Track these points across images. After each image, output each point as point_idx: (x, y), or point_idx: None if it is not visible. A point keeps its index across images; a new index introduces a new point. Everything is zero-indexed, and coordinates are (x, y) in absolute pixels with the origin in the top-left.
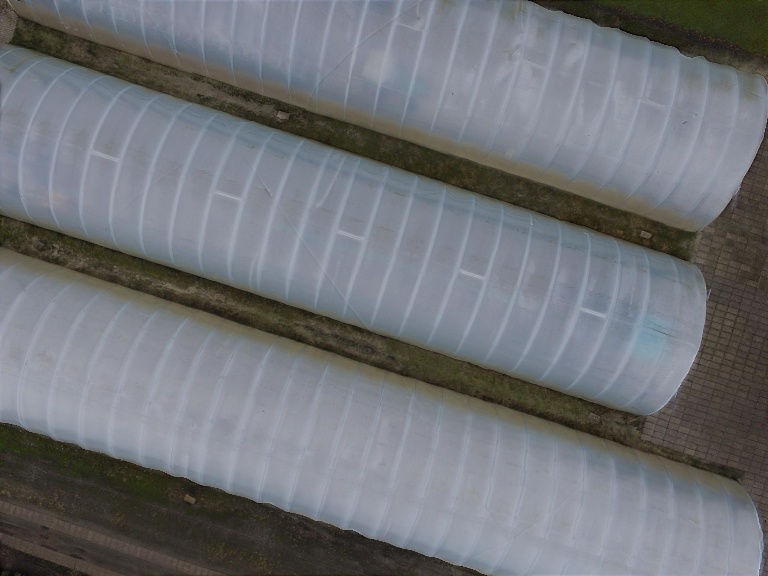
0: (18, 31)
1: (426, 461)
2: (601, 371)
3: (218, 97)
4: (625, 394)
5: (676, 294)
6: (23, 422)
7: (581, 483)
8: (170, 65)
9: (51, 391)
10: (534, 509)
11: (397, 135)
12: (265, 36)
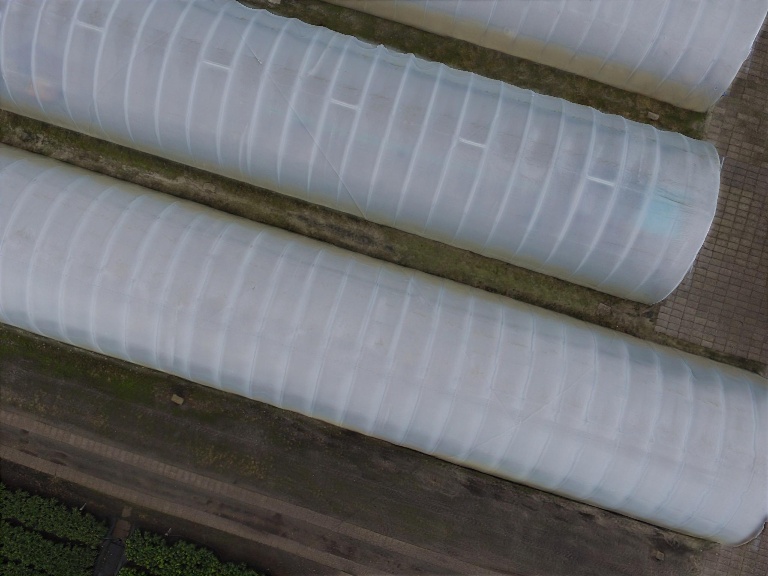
0: None
1: (426, 340)
2: (610, 246)
3: None
4: (637, 273)
5: (687, 162)
6: (1, 308)
7: (592, 365)
8: None
9: (30, 269)
10: (543, 390)
11: (392, 17)
12: None
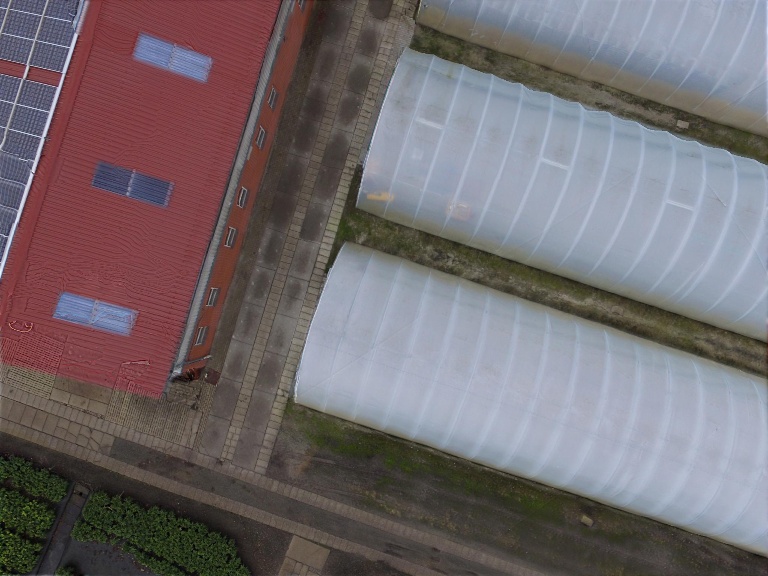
0: (416, 38)
1: None
2: None
3: (616, 105)
4: None
5: None
6: (449, 438)
7: None
8: (569, 73)
9: (498, 406)
10: None
11: None
12: (708, 44)
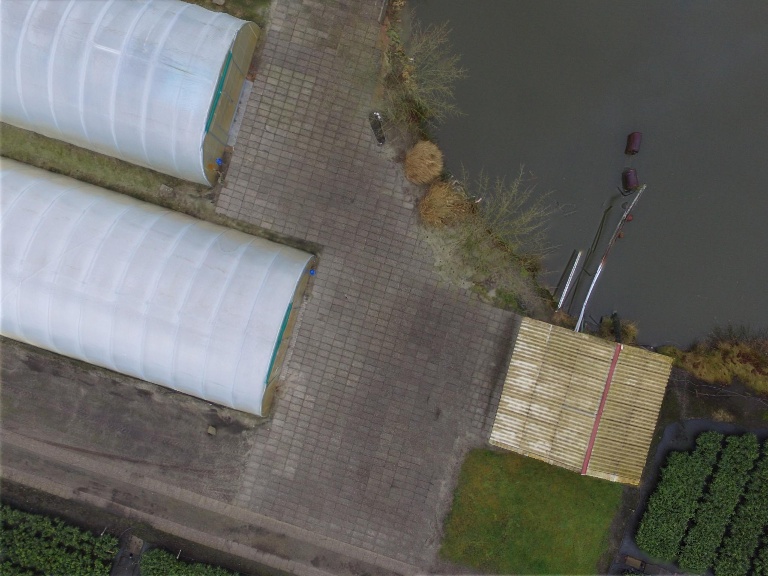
0: None
1: None
2: (128, 116)
3: None
4: (163, 146)
5: (201, 34)
6: None
7: (104, 231)
8: None
9: None
10: (43, 252)
11: None
12: None
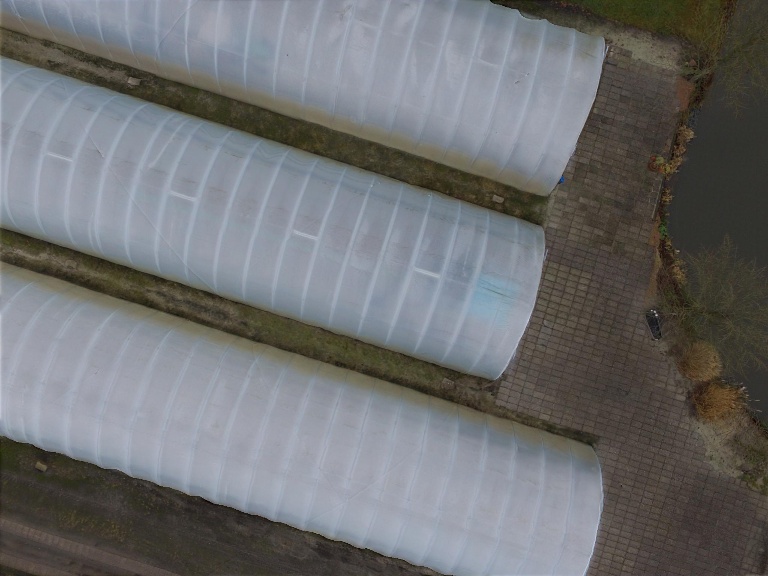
0: None
1: (260, 423)
2: (440, 332)
3: (69, 63)
4: (467, 356)
5: (513, 254)
6: None
7: (419, 445)
8: (20, 31)
9: None
10: (369, 470)
11: (247, 100)
12: None
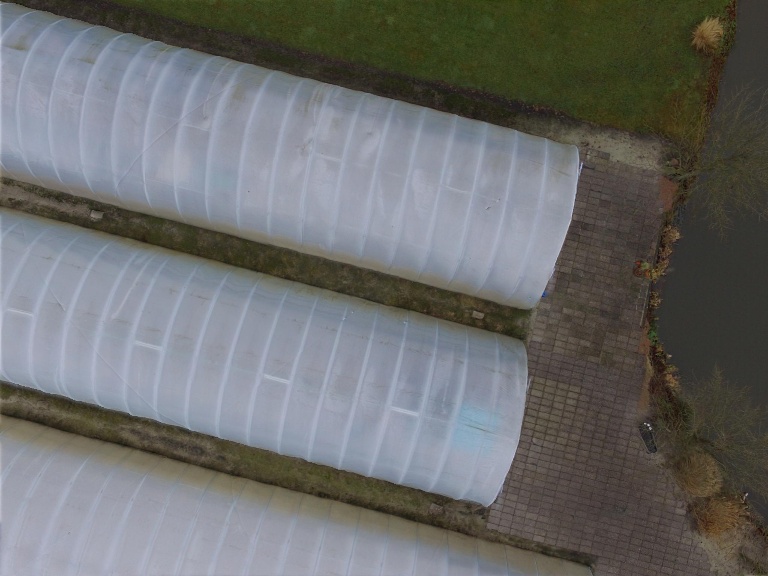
0: None
1: None
2: (422, 470)
3: (29, 200)
4: (453, 490)
5: (494, 386)
6: None
7: None
8: None
9: None
10: None
11: (213, 228)
12: (53, 144)
